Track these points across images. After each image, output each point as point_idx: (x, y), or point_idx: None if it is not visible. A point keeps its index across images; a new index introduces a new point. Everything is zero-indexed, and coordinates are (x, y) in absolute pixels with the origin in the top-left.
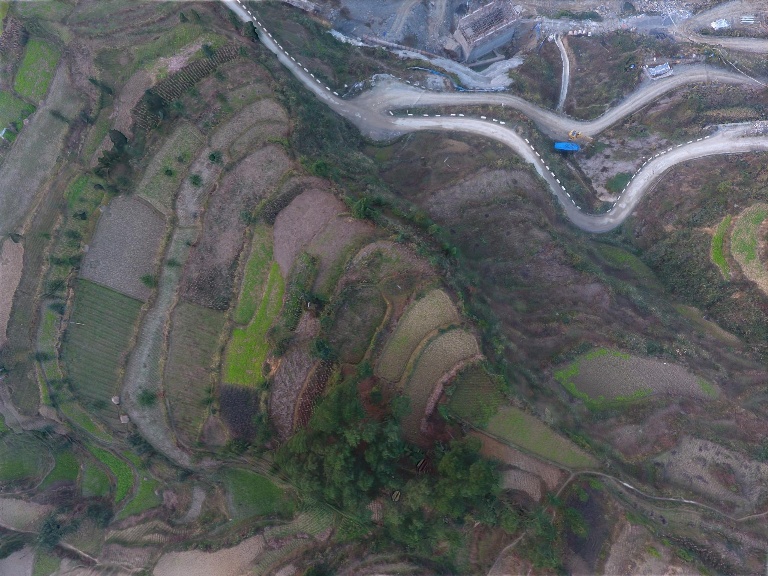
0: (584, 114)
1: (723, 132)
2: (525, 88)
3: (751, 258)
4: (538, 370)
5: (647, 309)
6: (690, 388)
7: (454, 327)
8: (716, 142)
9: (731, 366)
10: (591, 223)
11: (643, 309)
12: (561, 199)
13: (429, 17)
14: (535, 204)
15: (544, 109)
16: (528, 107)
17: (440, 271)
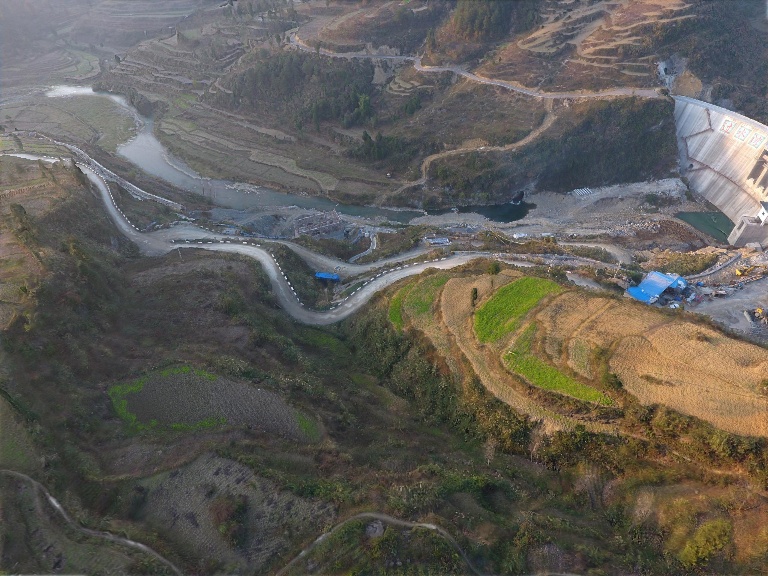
0: (359, 262)
1: (460, 256)
2: (308, 242)
3: (423, 311)
4: (94, 382)
5: (295, 358)
6: (282, 423)
7: (1, 302)
8: (452, 263)
9: (378, 424)
10: (311, 317)
11: (288, 356)
12: (287, 297)
13: (278, 225)
14: (240, 284)
15: (317, 253)
16: (303, 250)
17: (46, 272)
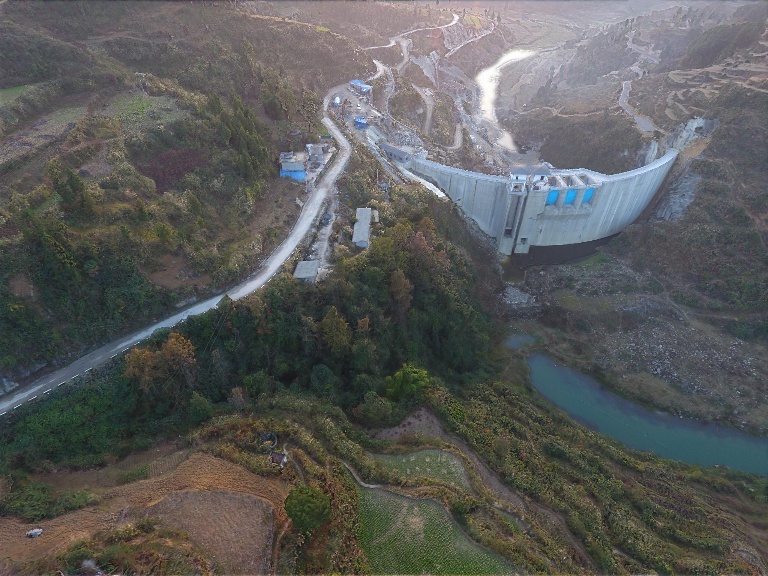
0: None
1: None
2: None
3: None
4: None
5: None
6: None
7: None
8: None
9: None
10: None
11: None
12: None
13: None
14: None
15: None
16: None
17: None
